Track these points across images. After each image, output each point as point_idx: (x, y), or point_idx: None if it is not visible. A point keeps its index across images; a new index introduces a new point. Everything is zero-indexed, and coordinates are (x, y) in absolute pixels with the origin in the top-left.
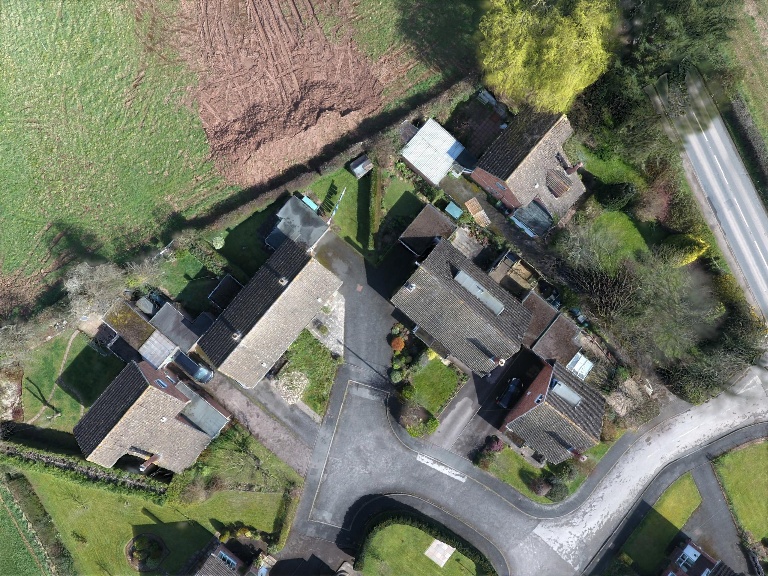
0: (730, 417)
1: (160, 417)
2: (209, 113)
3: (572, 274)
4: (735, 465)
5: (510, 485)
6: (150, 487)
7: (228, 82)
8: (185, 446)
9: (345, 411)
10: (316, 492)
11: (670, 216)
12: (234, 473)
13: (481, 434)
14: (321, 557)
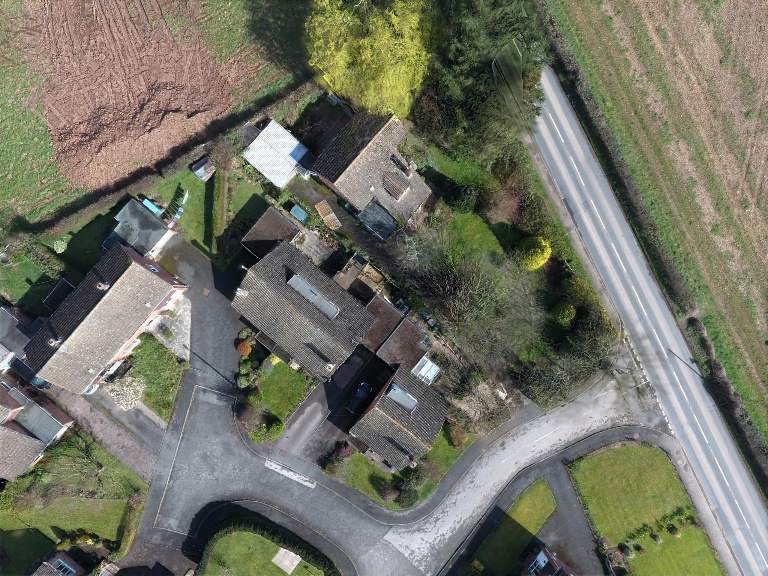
0: (587, 421)
1: None
2: (54, 115)
3: (425, 277)
4: (591, 470)
5: (360, 491)
6: None
7: (74, 84)
8: (16, 453)
9: (192, 417)
10: (161, 499)
11: (521, 218)
12: (77, 480)
13: (330, 439)
14: (166, 565)
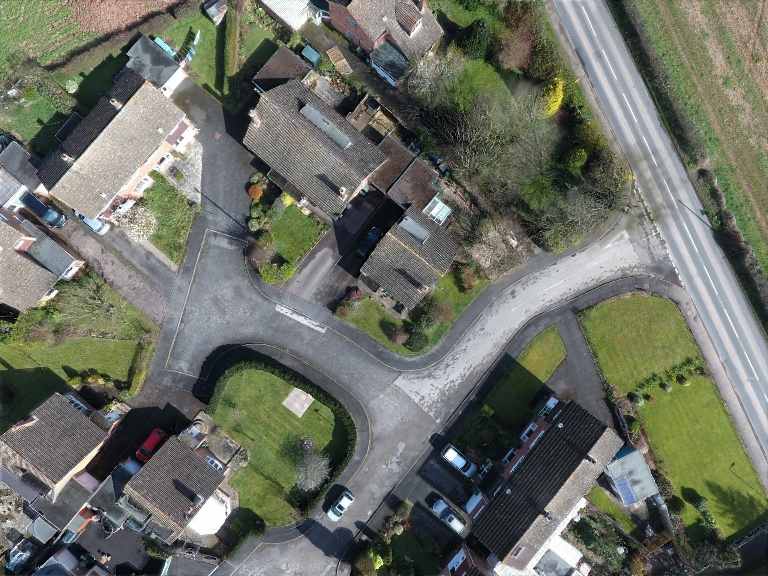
0: (597, 271)
1: None
2: None
3: (436, 125)
4: (601, 319)
5: (370, 336)
6: None
7: None
8: (28, 282)
9: (203, 260)
10: (173, 341)
11: (533, 63)
12: (88, 320)
13: (341, 284)
14: (177, 406)
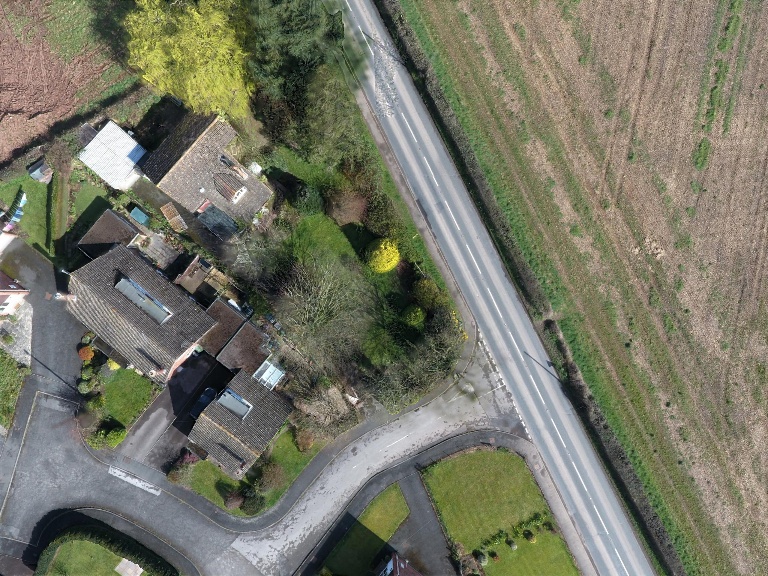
0: (441, 426)
1: None
2: None
3: (274, 280)
4: (445, 475)
5: (206, 498)
6: None
7: None
8: None
9: (33, 423)
10: (2, 507)
11: (369, 220)
12: None
13: (176, 446)
14: (5, 574)
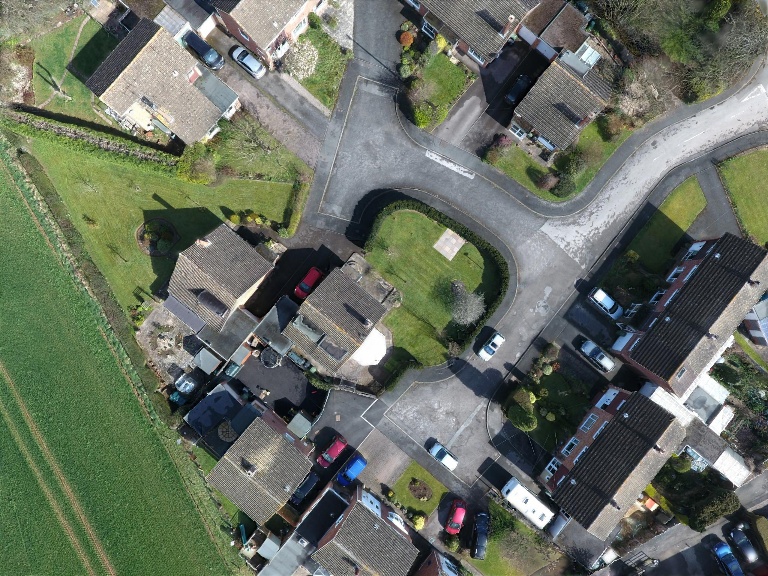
0: (735, 124)
1: (172, 70)
2: None
3: None
4: (739, 170)
5: (518, 182)
6: (161, 160)
7: None
8: (196, 114)
9: (354, 106)
10: (326, 185)
11: None
12: (244, 163)
13: (489, 132)
14: (331, 247)
